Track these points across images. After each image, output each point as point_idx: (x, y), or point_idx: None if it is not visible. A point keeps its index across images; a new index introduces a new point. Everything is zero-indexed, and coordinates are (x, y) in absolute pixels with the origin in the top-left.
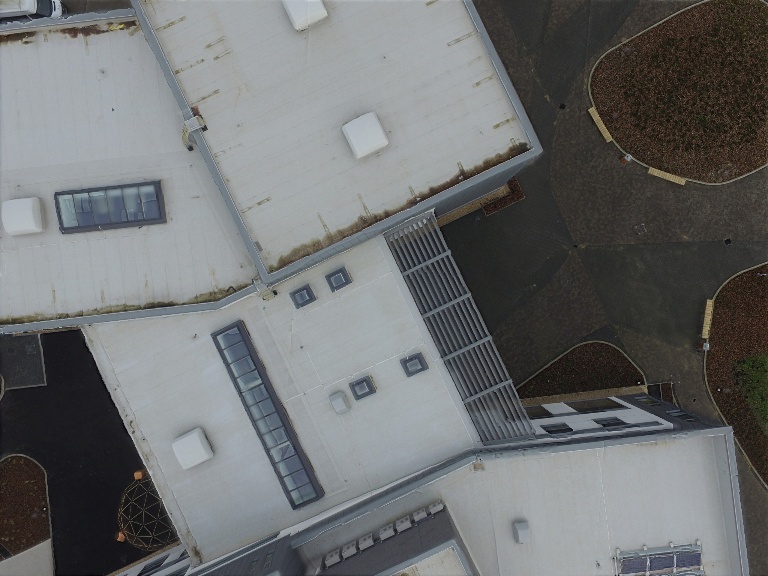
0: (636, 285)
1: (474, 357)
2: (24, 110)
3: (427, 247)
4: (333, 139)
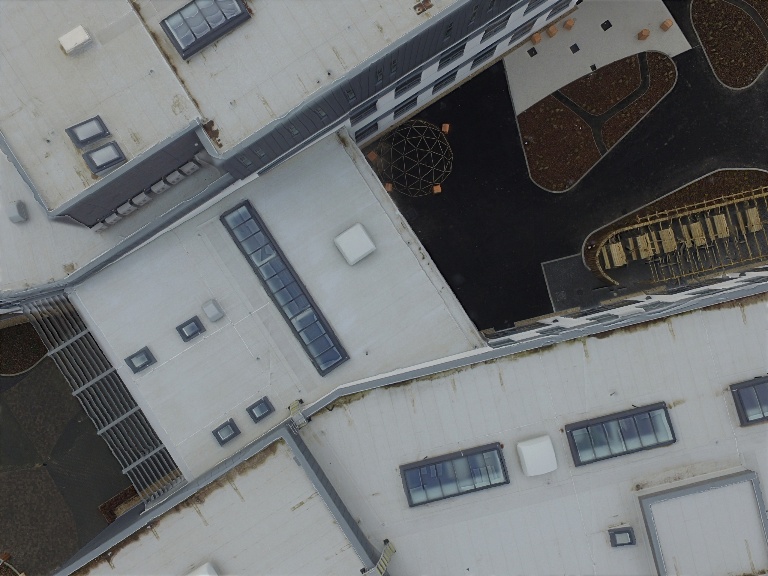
0: None
1: (88, 372)
2: (555, 558)
3: (147, 473)
4: (238, 575)
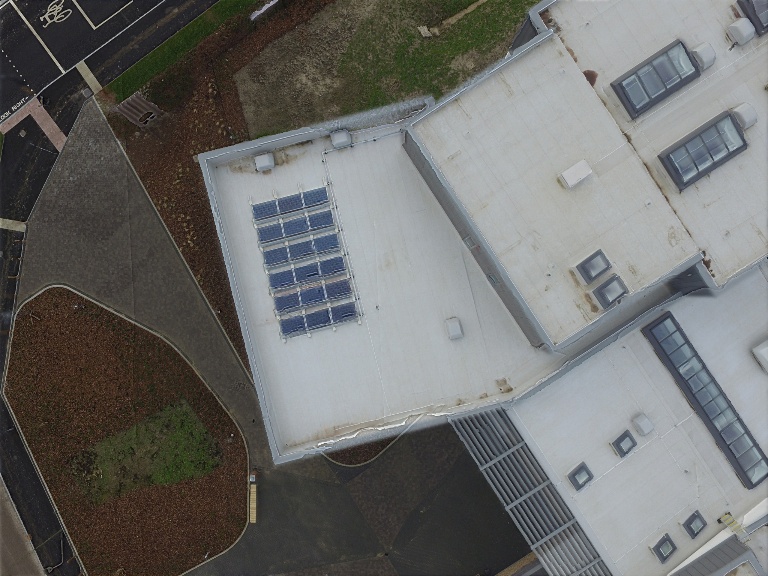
0: (324, 525)
1: (519, 486)
2: None
3: None
4: None
